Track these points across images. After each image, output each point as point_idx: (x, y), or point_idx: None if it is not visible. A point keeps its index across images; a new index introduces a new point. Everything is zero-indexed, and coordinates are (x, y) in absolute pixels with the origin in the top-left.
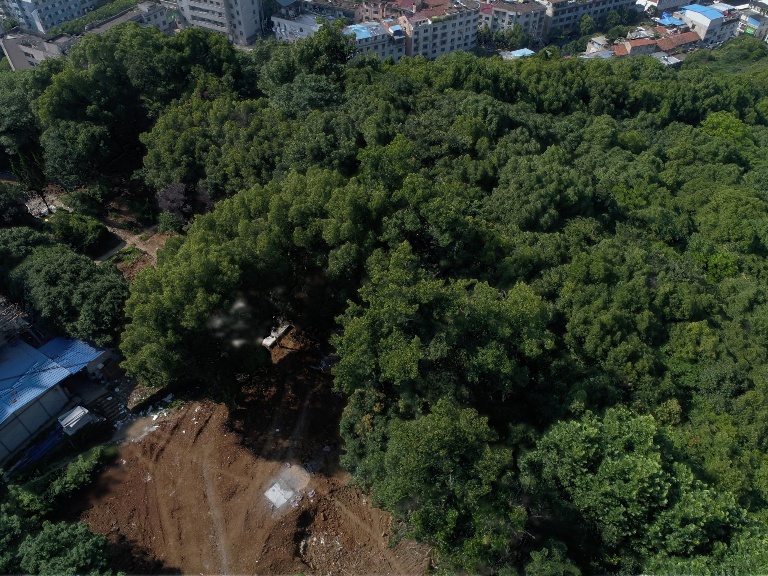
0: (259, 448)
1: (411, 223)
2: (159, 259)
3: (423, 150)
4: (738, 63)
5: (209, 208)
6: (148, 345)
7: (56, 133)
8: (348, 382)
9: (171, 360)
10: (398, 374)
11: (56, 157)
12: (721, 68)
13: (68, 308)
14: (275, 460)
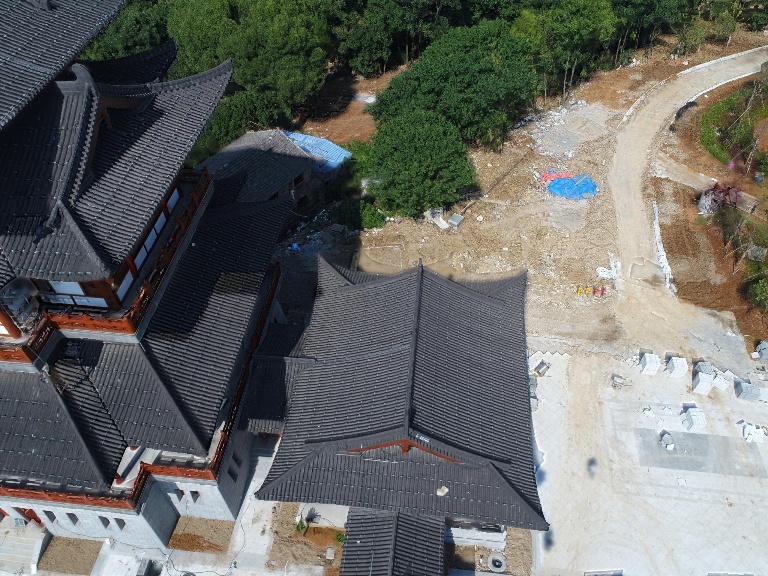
0: (342, 106)
1: None
2: (249, 45)
3: (145, 1)
4: None
5: None
6: (315, 52)
7: None
8: None
9: None
10: None
11: None
12: None
13: None
14: (350, 102)
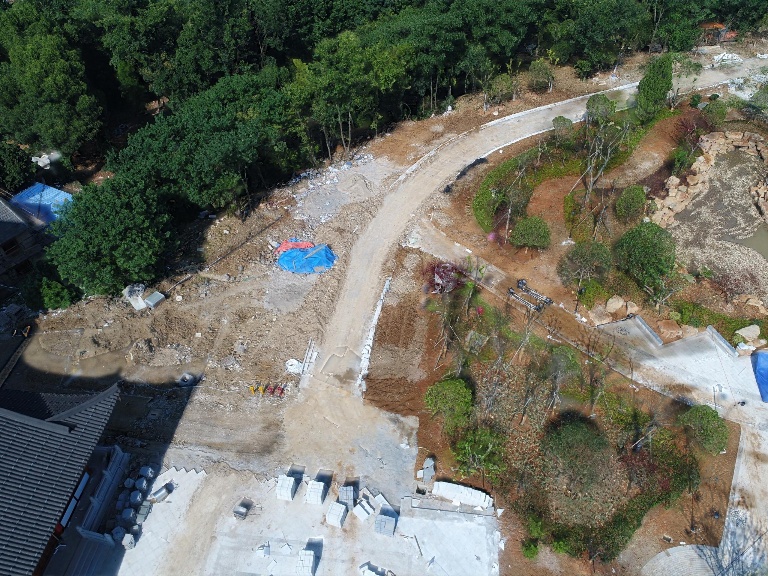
0: None
1: (62, 0)
2: (4, 92)
3: None
4: None
5: None
6: (80, 100)
7: None
8: None
9: None
10: (162, 14)
11: None
12: None
13: None
14: None
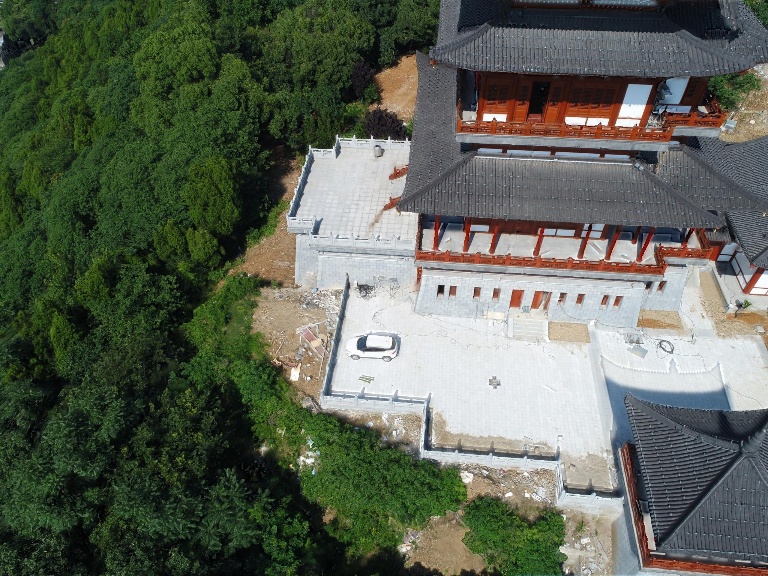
0: None
1: None
2: None
3: None
4: (52, 7)
5: (370, 68)
6: None
7: (299, 97)
8: None
9: None
10: None
11: (331, 97)
12: (79, 2)
13: None
14: None
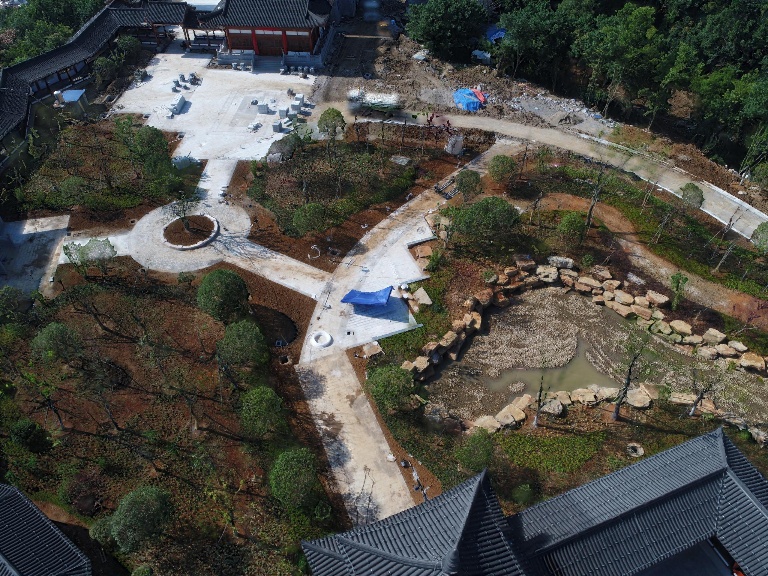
0: None
1: None
2: None
3: None
4: None
5: None
6: None
7: None
8: (678, 12)
9: (596, 6)
10: None
11: None
12: None
13: (519, 5)
14: None
